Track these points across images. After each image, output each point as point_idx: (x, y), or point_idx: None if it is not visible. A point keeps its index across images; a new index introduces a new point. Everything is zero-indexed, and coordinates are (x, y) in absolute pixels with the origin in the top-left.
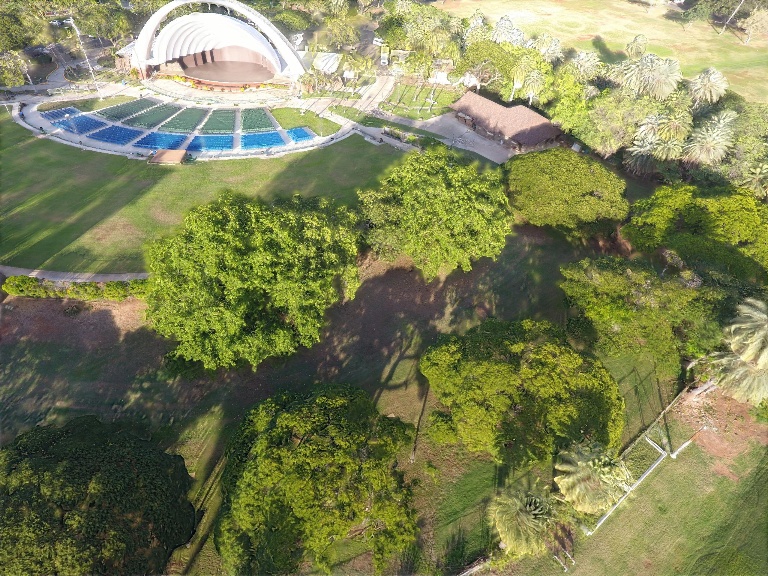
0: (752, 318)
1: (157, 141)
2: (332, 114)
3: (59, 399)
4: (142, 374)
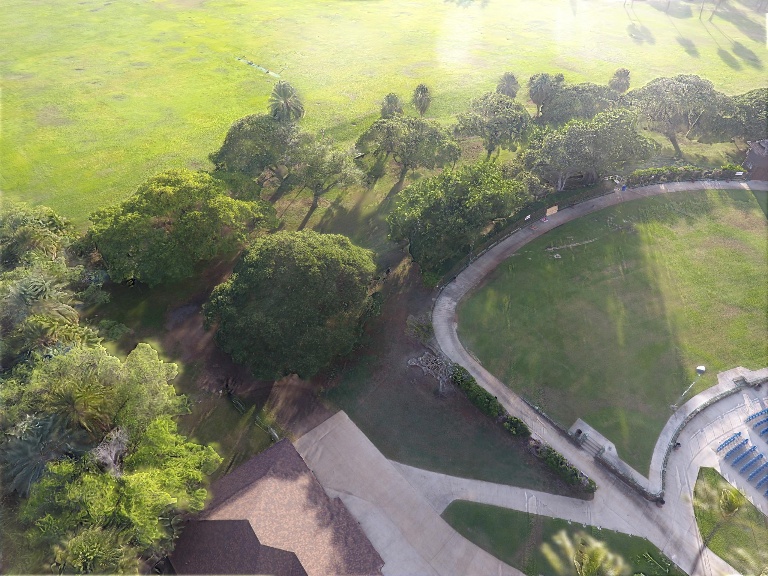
0: (293, 107)
1: None
2: None
3: None
4: None
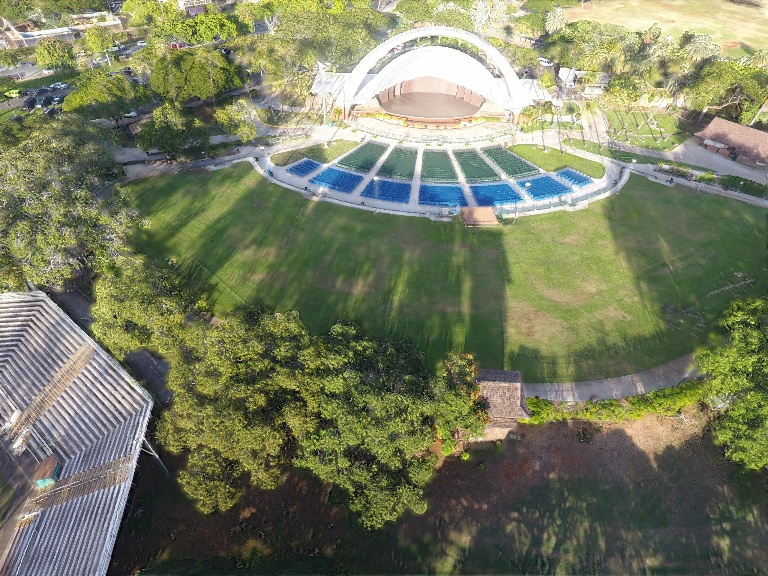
0: None
1: (439, 196)
2: (575, 149)
3: (646, 555)
4: (714, 512)
